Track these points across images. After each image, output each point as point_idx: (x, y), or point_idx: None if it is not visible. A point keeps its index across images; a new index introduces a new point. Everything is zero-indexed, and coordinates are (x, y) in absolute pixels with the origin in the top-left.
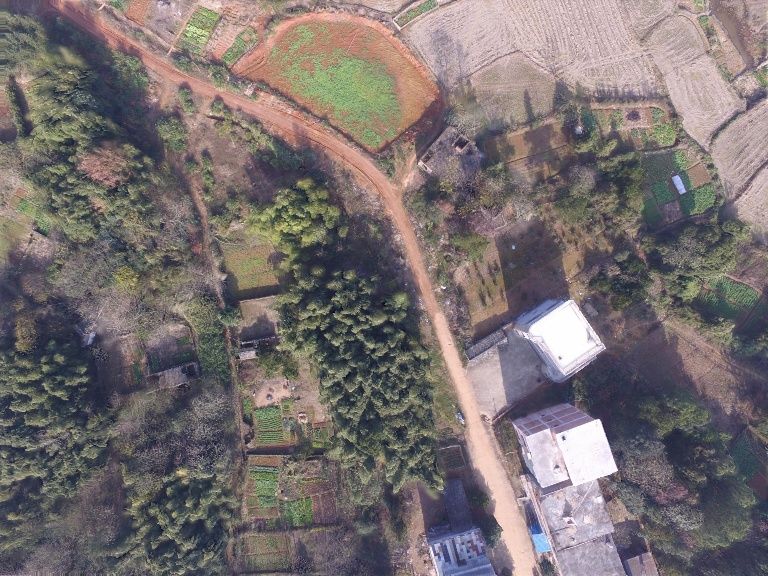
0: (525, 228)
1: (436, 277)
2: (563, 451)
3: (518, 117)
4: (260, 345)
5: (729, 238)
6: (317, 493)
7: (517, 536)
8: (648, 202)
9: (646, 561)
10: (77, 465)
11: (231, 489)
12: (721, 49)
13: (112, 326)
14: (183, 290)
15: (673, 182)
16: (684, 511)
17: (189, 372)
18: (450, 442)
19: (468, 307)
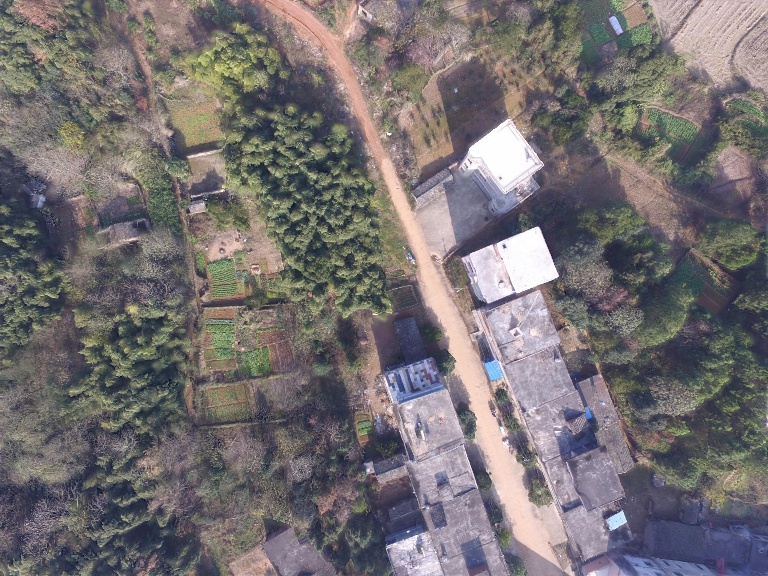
0: (466, 71)
1: (381, 123)
2: (504, 259)
3: None
4: (210, 198)
5: (659, 53)
6: (274, 342)
7: (472, 371)
8: (586, 43)
9: (597, 383)
10: (28, 311)
11: (185, 333)
12: None
13: (62, 190)
14: (131, 148)
15: (610, 23)
16: (624, 310)
17: (140, 228)
18: (402, 283)
19: (413, 149)
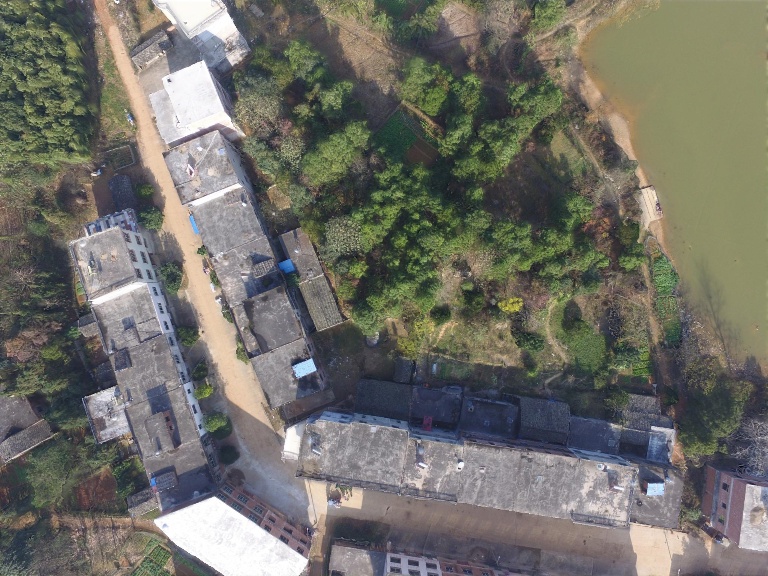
0: None
1: None
2: (169, 93)
3: None
4: None
5: None
6: (3, 207)
7: (187, 229)
8: None
9: (300, 235)
10: None
11: None
12: None
13: None
14: None
15: None
16: None
17: None
18: (122, 145)
19: (134, 13)
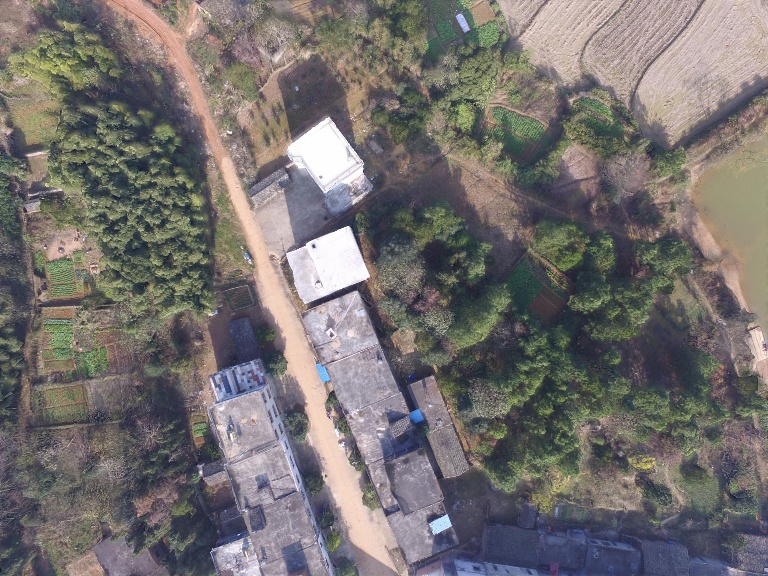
0: (308, 69)
1: (221, 122)
2: (314, 259)
3: None
4: (47, 197)
5: (483, 51)
6: (112, 343)
7: (308, 372)
8: (432, 41)
9: (429, 385)
10: None
11: (12, 333)
12: None
13: None
14: None
15: (457, 21)
16: (434, 311)
17: None
18: (239, 283)
19: (251, 148)
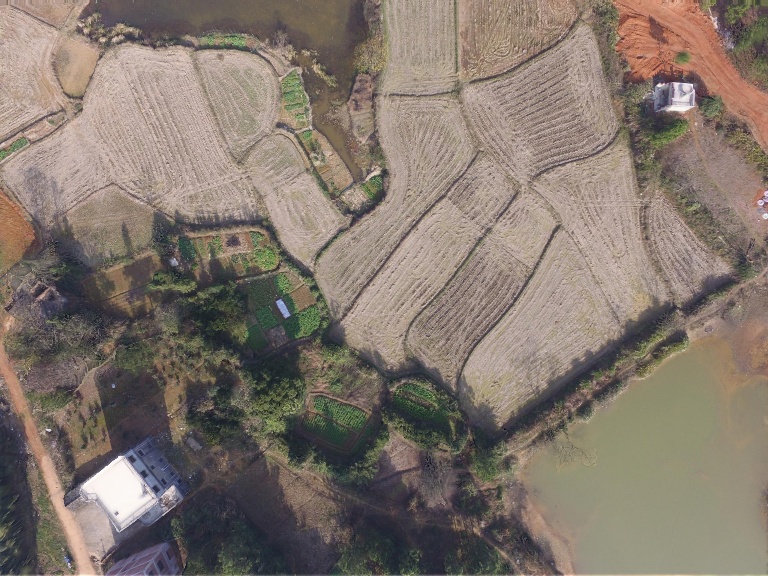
0: None
1: None
2: None
3: (118, 251)
4: None
5: (276, 383)
6: None
7: None
8: (252, 329)
9: None
10: None
11: None
12: (327, 163)
13: None
14: None
15: (277, 306)
16: None
17: None
18: None
19: (67, 451)
